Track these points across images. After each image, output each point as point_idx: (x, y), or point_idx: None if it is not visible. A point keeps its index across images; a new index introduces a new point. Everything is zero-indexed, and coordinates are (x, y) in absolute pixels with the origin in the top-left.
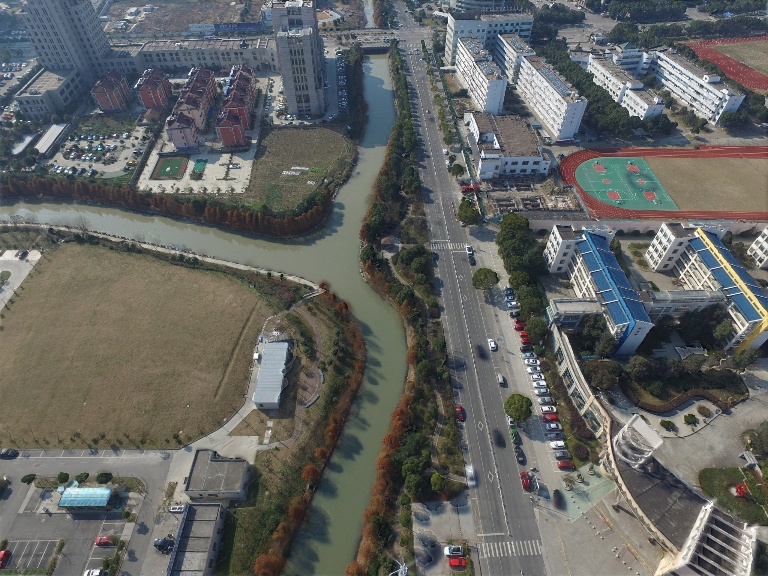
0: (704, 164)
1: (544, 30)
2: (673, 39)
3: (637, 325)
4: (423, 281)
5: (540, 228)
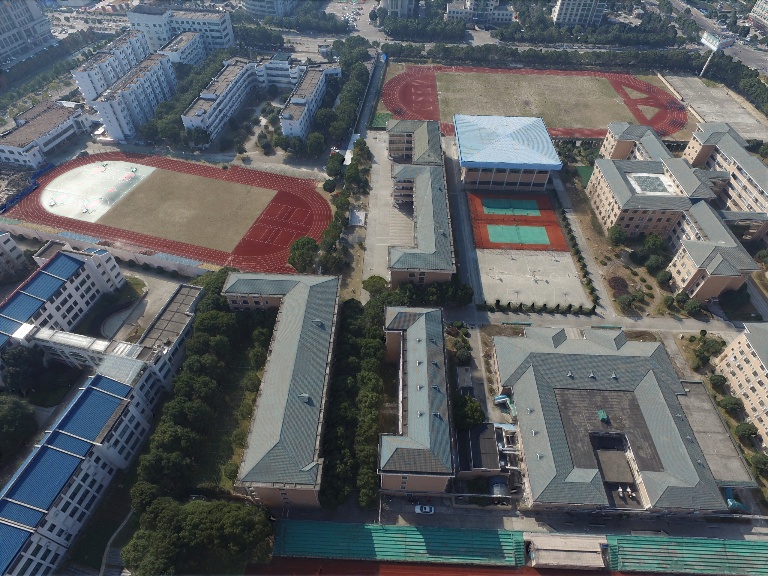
0: (202, 184)
1: (261, 34)
2: (411, 60)
3: None
4: None
5: None
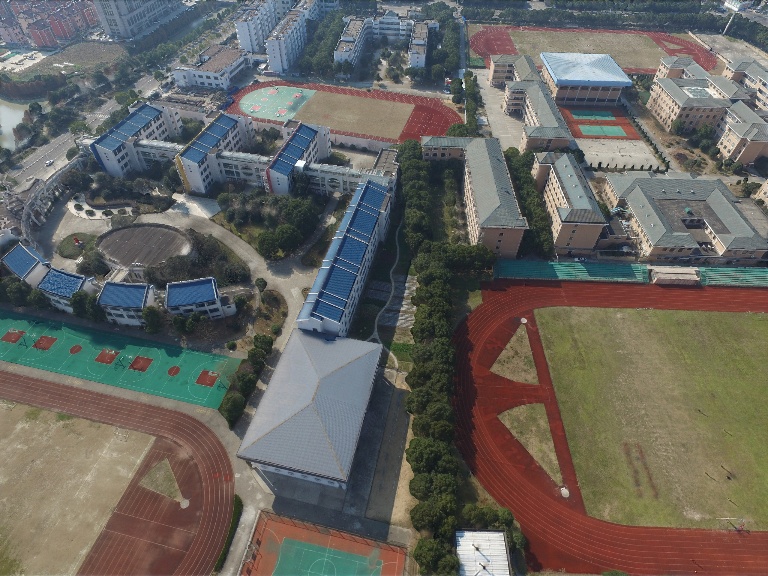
0: (356, 100)
1: (361, 1)
2: (485, 22)
3: (101, 150)
4: (46, 125)
5: None
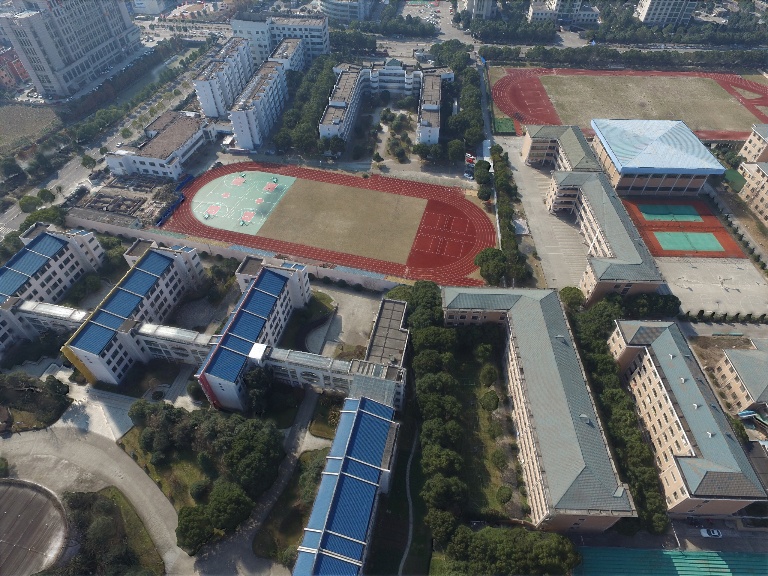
0: (349, 194)
1: (357, 40)
2: (508, 63)
3: None
4: None
5: (90, 227)
